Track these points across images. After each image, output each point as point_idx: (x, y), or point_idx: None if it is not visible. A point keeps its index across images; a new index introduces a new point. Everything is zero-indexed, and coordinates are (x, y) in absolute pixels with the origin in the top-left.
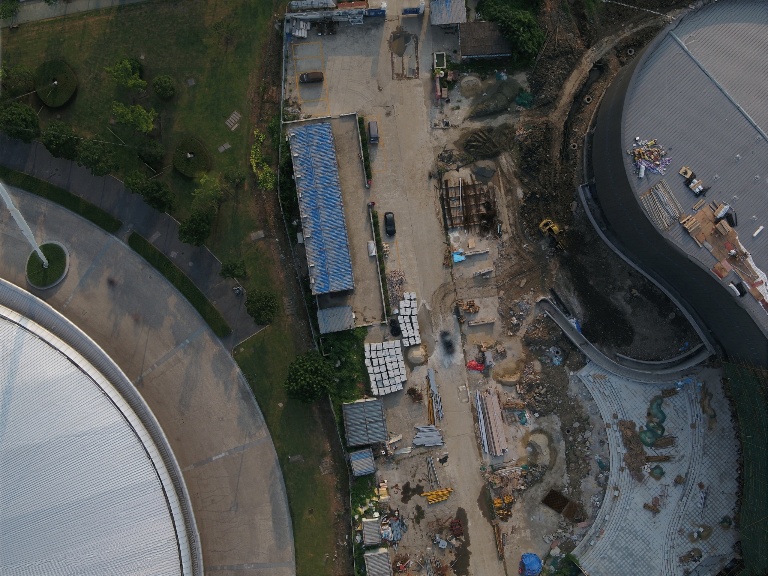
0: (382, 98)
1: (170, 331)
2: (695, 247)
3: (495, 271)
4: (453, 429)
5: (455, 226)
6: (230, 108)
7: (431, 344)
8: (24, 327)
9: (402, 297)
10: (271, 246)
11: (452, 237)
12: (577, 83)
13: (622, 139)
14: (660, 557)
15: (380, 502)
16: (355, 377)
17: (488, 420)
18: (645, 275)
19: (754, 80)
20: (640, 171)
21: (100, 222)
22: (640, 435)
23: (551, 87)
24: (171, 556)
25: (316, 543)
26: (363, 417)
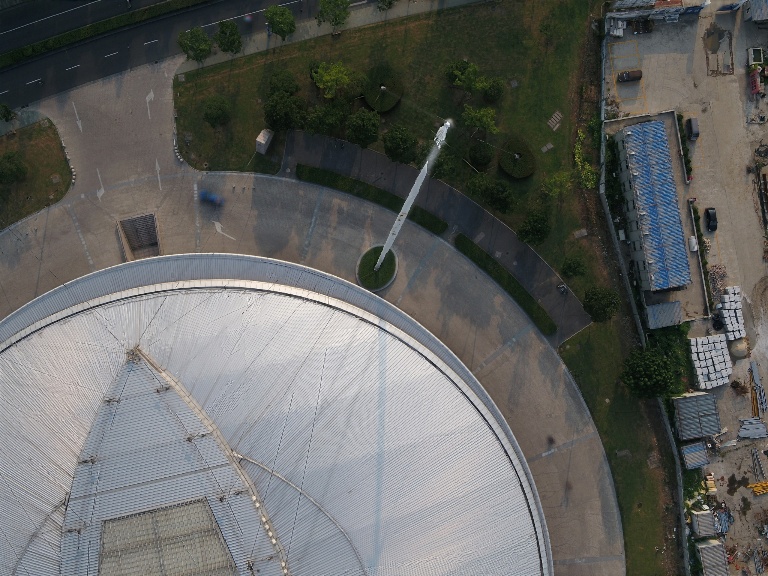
0: (698, 95)
1: (497, 330)
2: None
3: None
4: None
5: None
6: (552, 108)
7: (753, 337)
8: (384, 329)
9: (723, 291)
10: (593, 244)
11: None
12: None
13: None
14: None
15: (709, 495)
16: (682, 372)
17: None
18: None
19: None
20: None
21: (427, 224)
22: None
23: None
24: (532, 551)
25: (646, 536)
26: (696, 411)
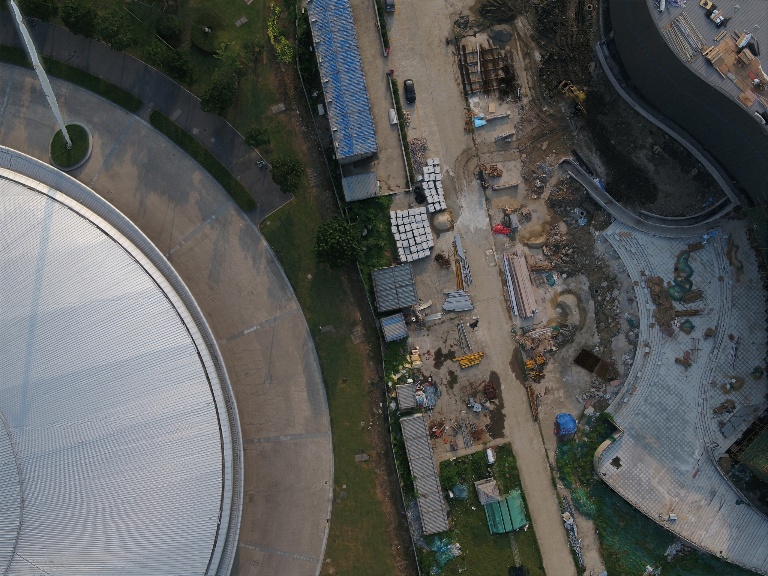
0: None
1: (196, 208)
2: (719, 78)
3: (516, 135)
4: (482, 293)
5: (475, 91)
6: None
7: (456, 210)
8: (53, 198)
9: (425, 164)
10: (292, 119)
11: (472, 103)
12: None
13: None
14: (694, 410)
15: (413, 368)
16: (382, 245)
17: (516, 282)
18: (666, 130)
19: None
20: (661, 4)
21: (121, 101)
22: (668, 290)
23: None
24: (210, 419)
25: (351, 412)
26: (392, 282)
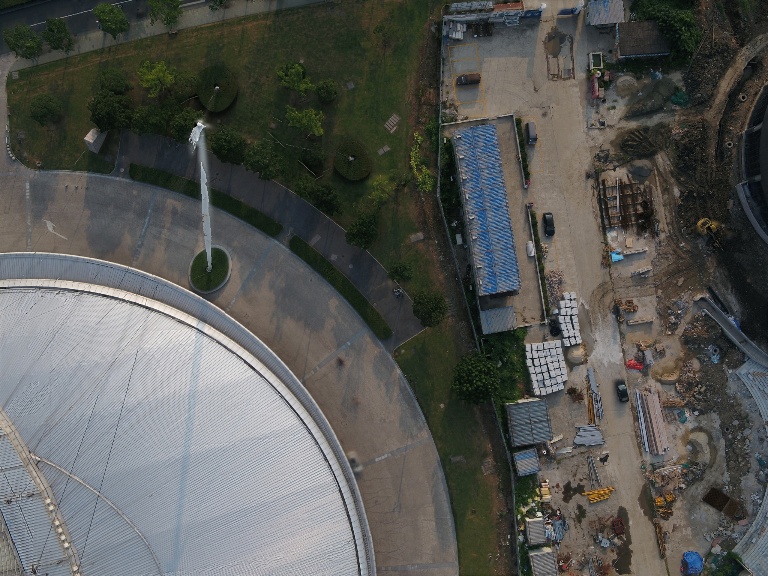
0: (538, 99)
1: (331, 333)
2: None
3: (653, 270)
4: (613, 428)
5: (613, 226)
6: (389, 111)
7: (590, 344)
8: (202, 331)
9: (561, 297)
10: (430, 248)
11: (610, 237)
12: (732, 81)
13: None
14: None
15: (543, 502)
16: (517, 377)
17: (649, 419)
18: None
19: None
20: None
21: (262, 226)
22: None
23: (707, 86)
24: (349, 557)
25: (479, 543)
26: (528, 417)
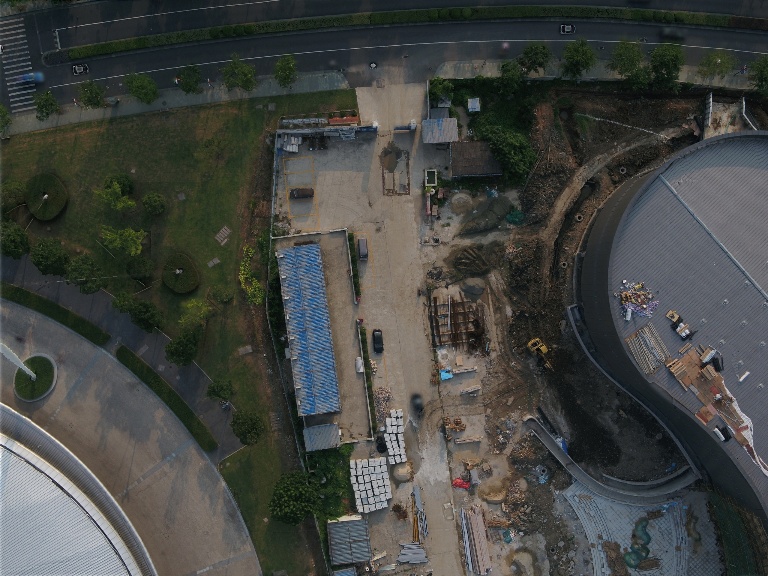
0: (372, 214)
1: (156, 444)
2: (681, 390)
3: (482, 389)
4: (437, 546)
5: (443, 344)
6: (220, 223)
7: (417, 461)
8: (10, 450)
9: (389, 414)
10: (259, 361)
11: (440, 354)
12: (568, 201)
13: (609, 283)
14: None
15: None
16: (340, 494)
17: (473, 539)
18: (633, 397)
19: (745, 211)
20: (627, 314)
21: (88, 335)
22: (624, 557)
23: (542, 206)
24: None
25: None
26: (347, 536)
